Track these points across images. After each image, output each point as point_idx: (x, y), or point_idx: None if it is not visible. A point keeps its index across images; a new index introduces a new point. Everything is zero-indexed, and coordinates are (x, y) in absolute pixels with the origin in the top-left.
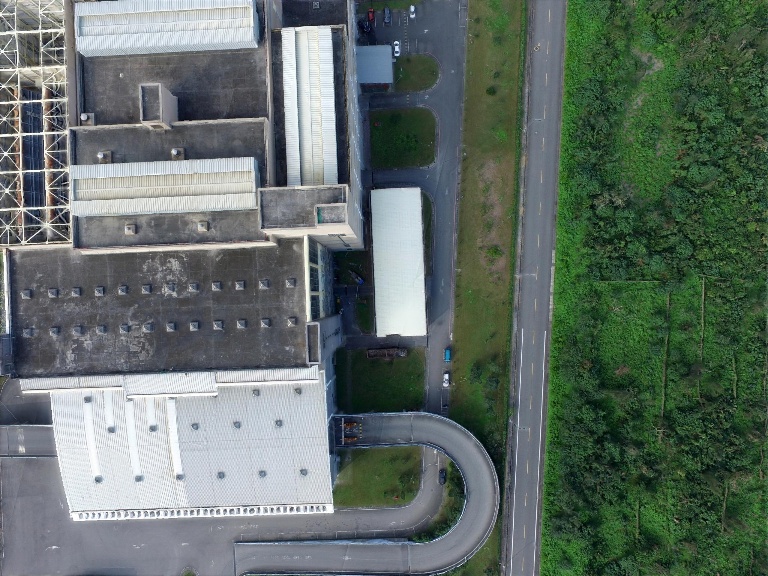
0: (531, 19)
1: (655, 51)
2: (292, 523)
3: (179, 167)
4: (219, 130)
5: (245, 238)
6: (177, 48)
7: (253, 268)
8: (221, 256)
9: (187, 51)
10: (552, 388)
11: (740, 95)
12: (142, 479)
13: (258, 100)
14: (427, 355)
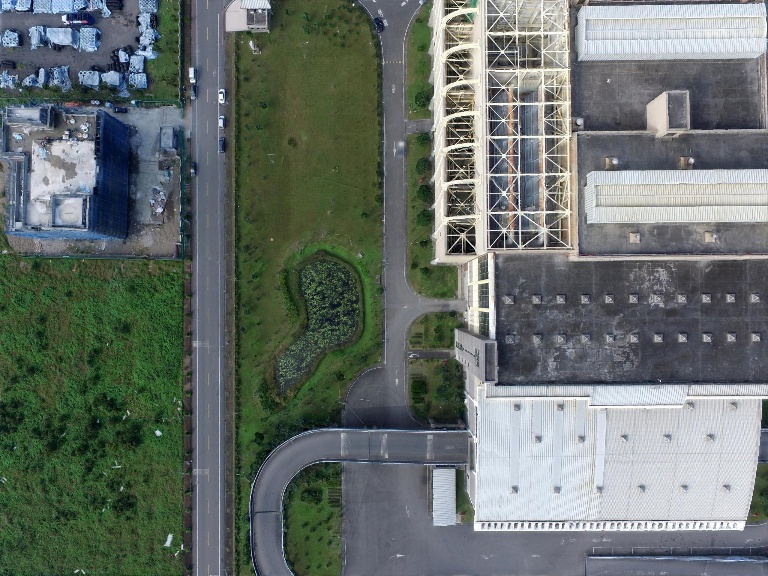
0: None
1: None
2: (646, 538)
3: (706, 176)
4: (726, 140)
5: (750, 250)
6: (680, 56)
7: (743, 281)
8: (711, 267)
9: (682, 59)
10: None
11: None
12: (560, 490)
13: (749, 111)
14: None
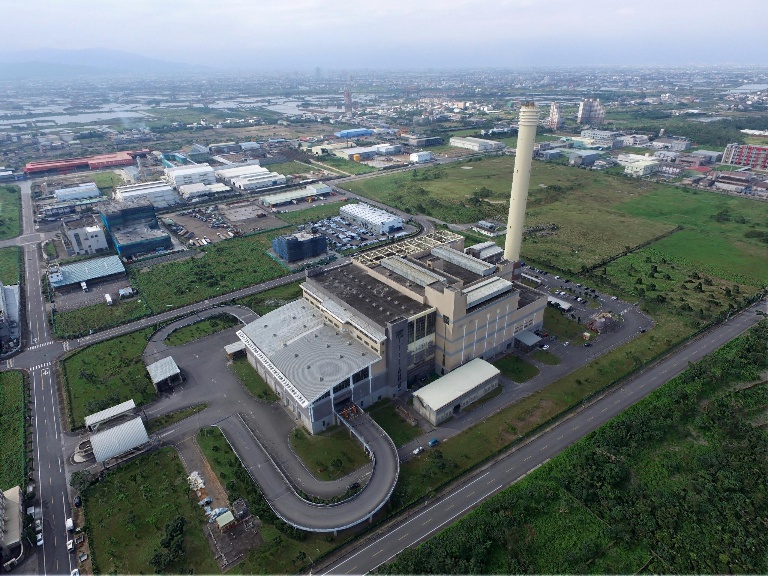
0: (629, 381)
1: (704, 434)
2: (266, 431)
3: (423, 269)
4: None
5: None
6: (458, 263)
7: (407, 303)
8: (402, 296)
9: (460, 266)
10: (472, 513)
11: (766, 495)
12: (275, 336)
13: None
14: (423, 436)
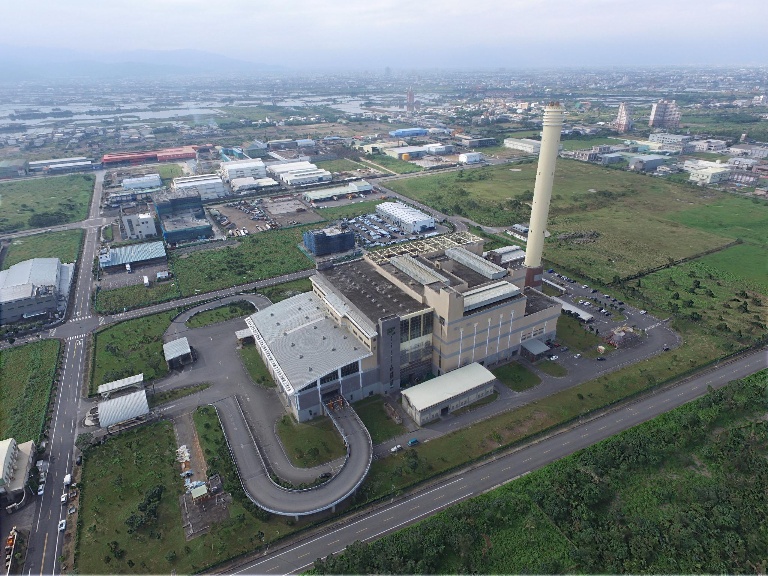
0: (638, 400)
1: (709, 465)
2: (257, 414)
3: (429, 269)
4: None
5: None
6: (469, 265)
7: (406, 302)
8: (404, 294)
9: (471, 269)
10: (435, 516)
11: (767, 538)
12: (278, 325)
13: None
14: (405, 434)
